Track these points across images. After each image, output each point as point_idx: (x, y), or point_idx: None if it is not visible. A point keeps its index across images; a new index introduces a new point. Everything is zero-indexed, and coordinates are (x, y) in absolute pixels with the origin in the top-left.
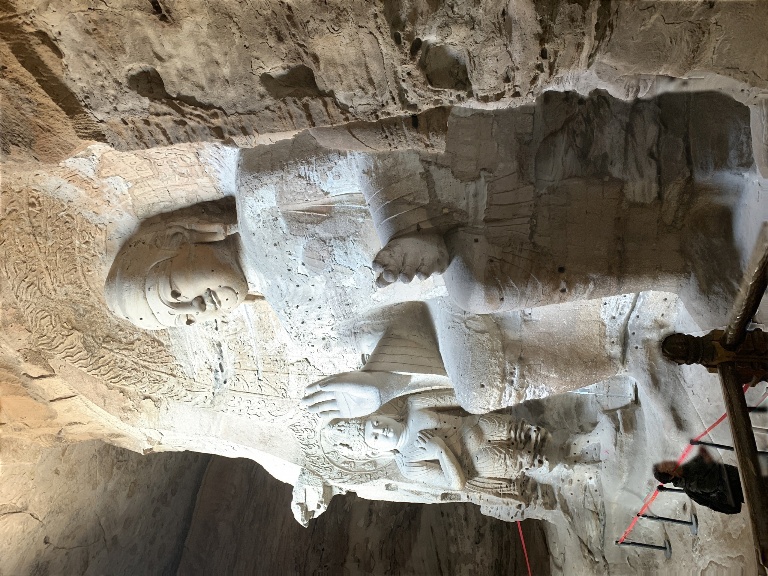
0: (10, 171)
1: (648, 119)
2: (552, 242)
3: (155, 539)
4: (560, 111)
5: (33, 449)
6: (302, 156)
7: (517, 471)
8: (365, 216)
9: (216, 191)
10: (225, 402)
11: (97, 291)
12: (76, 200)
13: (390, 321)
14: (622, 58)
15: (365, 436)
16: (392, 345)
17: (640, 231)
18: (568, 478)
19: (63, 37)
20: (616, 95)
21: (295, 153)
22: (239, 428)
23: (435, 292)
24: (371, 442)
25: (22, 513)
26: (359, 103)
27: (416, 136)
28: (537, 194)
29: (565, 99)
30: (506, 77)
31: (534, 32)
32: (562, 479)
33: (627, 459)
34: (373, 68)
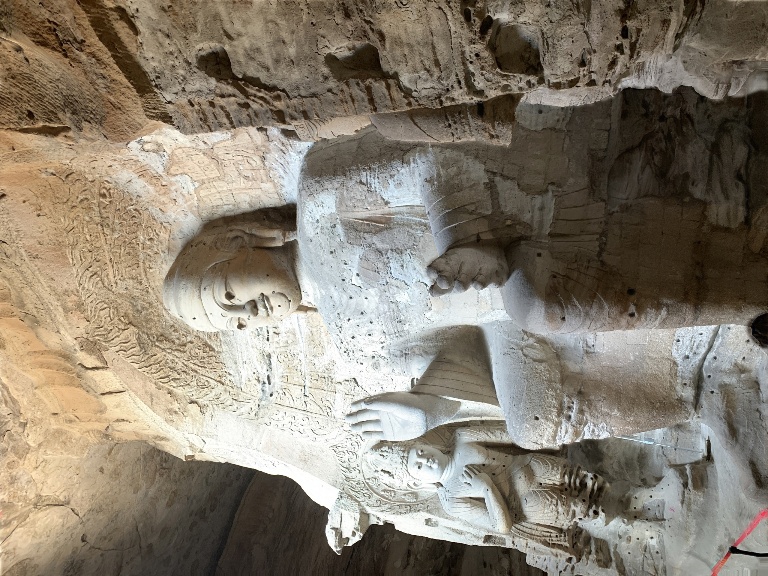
0: (82, 151)
1: (736, 139)
2: (622, 262)
3: (189, 554)
4: (638, 127)
5: (81, 443)
6: (365, 162)
7: (569, 520)
8: (425, 230)
9: (279, 197)
10: (269, 415)
11: (156, 289)
12: (145, 196)
13: (443, 345)
14: (713, 40)
15: (408, 464)
16: (443, 369)
17: (722, 257)
18: (626, 535)
19: (140, 14)
20: (703, 92)
21: (358, 159)
22: (281, 443)
23: (492, 316)
24: (414, 471)
25: (64, 507)
26: (423, 87)
27: (481, 125)
28: (608, 211)
29: (644, 115)
30: (581, 61)
31: (615, 8)
32: (619, 535)
33: (695, 519)
34: (440, 48)
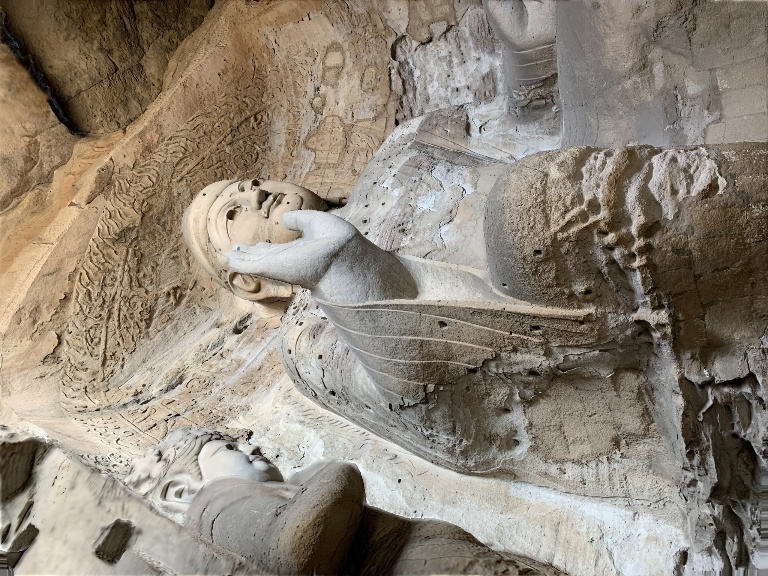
0: None
1: None
2: None
3: None
4: None
5: None
6: None
7: None
8: None
9: None
10: None
11: None
12: (273, 154)
13: None
14: None
15: (216, 440)
16: None
17: None
18: None
19: None
20: None
21: None
22: None
23: None
24: (212, 450)
25: None
26: None
27: None
28: None
29: None
30: None
31: None
32: None
33: None
34: None
